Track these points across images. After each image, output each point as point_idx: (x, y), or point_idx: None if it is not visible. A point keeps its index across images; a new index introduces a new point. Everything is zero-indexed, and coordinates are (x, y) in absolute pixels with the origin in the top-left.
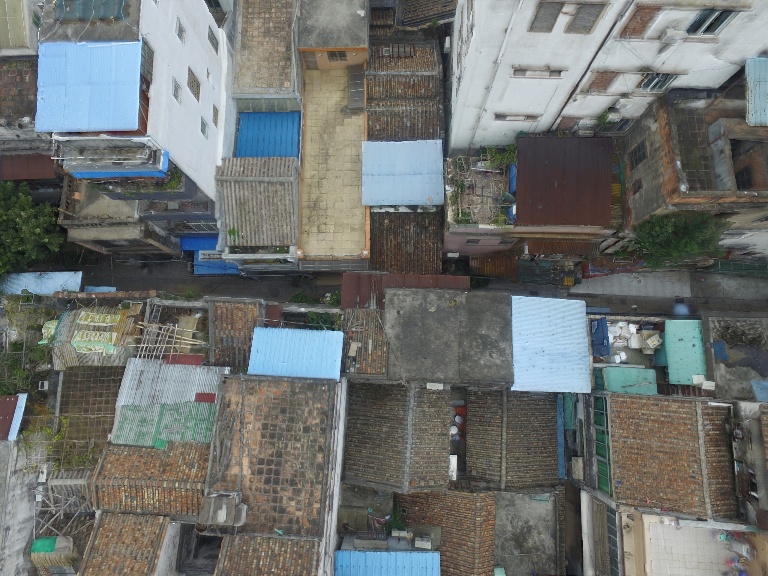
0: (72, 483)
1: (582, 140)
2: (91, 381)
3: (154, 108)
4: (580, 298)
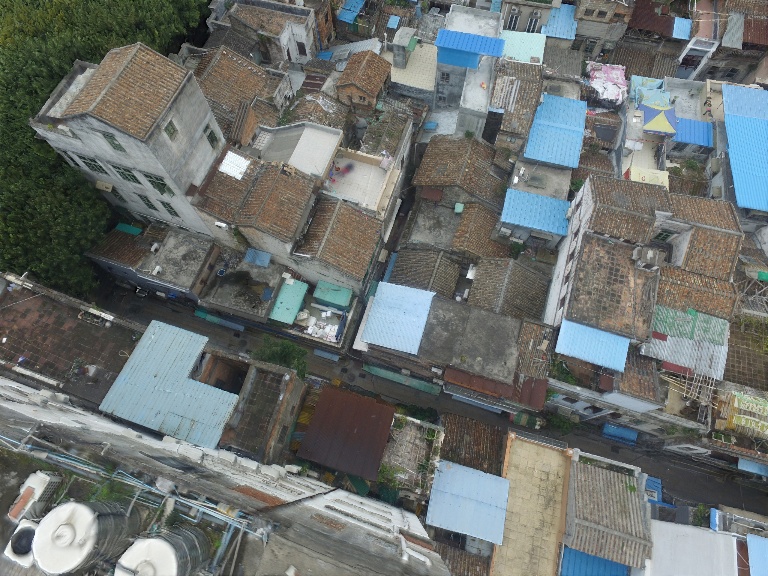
0: (752, 311)
1: (323, 462)
2: (749, 385)
3: (732, 570)
4: (323, 375)
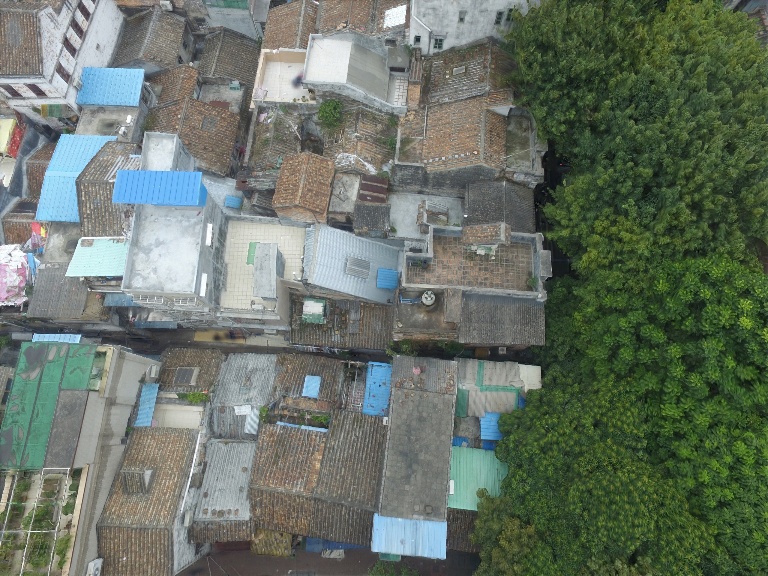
0: None
1: None
2: None
3: None
4: None
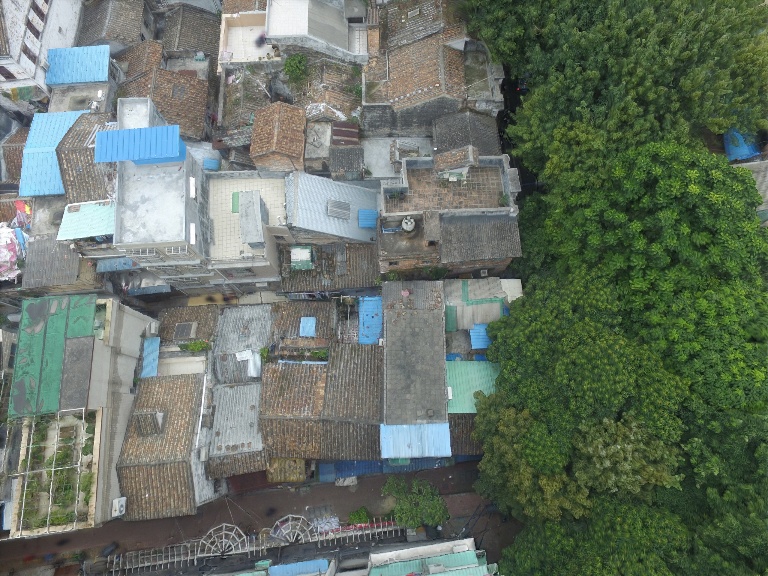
0: None
1: None
2: None
3: None
4: None
